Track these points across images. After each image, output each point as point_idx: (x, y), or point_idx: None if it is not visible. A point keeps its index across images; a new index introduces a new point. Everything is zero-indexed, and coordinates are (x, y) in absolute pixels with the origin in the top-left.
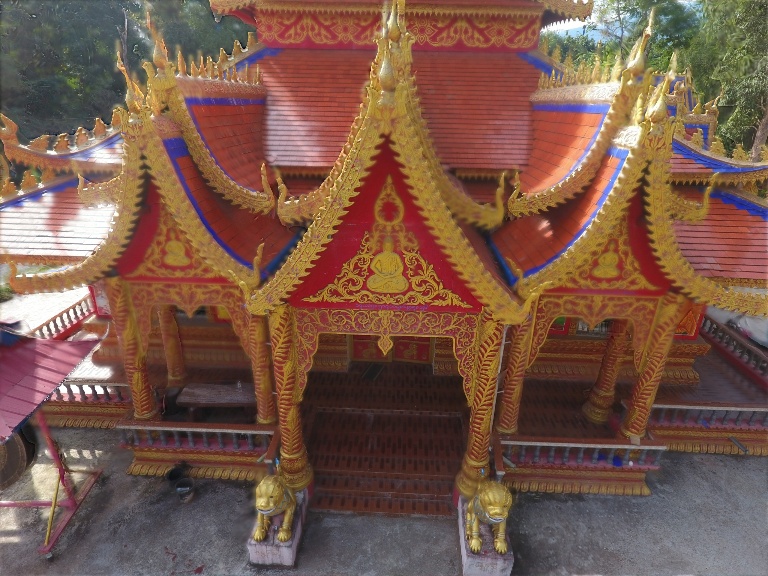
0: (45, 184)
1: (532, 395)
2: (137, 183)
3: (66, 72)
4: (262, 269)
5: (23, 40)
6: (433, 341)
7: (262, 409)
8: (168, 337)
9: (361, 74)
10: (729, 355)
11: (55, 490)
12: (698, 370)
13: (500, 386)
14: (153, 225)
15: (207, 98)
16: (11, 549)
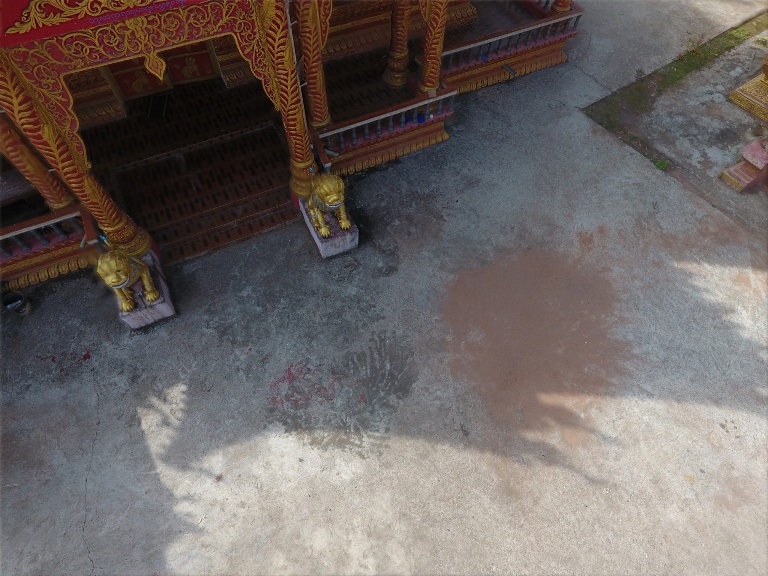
0: None
1: (334, 79)
2: None
3: None
4: None
5: None
6: (210, 47)
7: (48, 193)
8: None
9: None
10: None
11: None
12: (475, 4)
13: (301, 78)
14: None
15: None
16: None
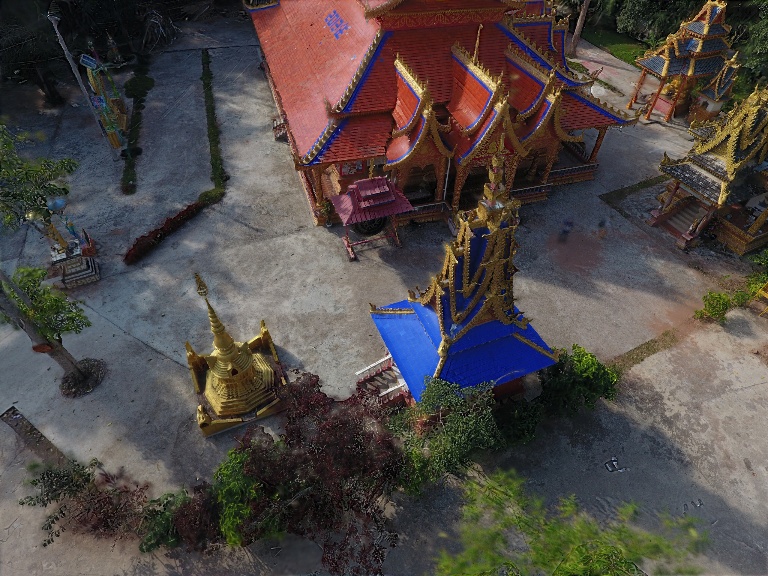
0: (336, 125)
1: None
2: (426, 132)
3: None
4: (449, 150)
5: None
6: None
7: None
8: None
9: (434, 45)
10: (569, 147)
11: None
12: (559, 156)
13: None
14: None
15: None
16: None
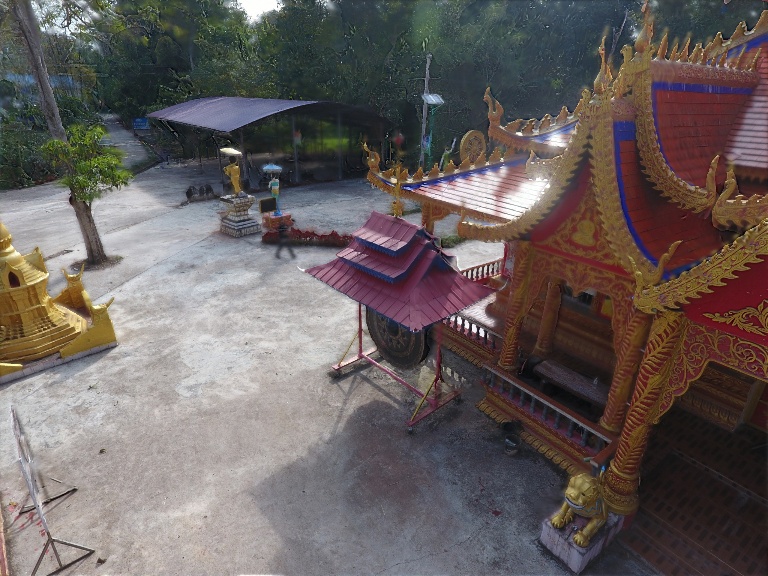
0: (505, 159)
1: None
2: (575, 160)
3: (554, 74)
4: (668, 270)
5: (532, 48)
6: None
7: (609, 413)
8: (549, 310)
9: None
10: None
11: (429, 387)
12: None
13: None
14: (575, 202)
15: (678, 83)
16: (393, 411)
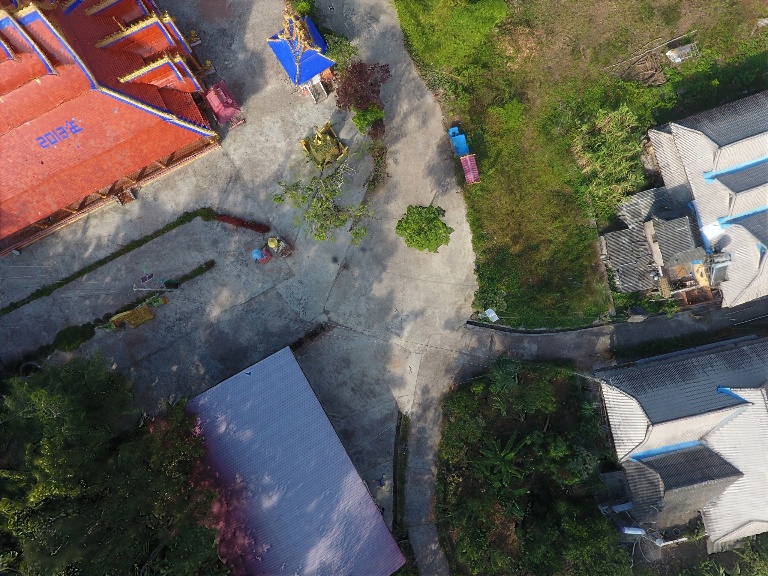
0: None
1: None
2: None
3: None
4: None
5: None
6: None
7: None
8: None
9: (98, 57)
10: None
11: None
12: None
13: None
14: None
15: None
16: None
